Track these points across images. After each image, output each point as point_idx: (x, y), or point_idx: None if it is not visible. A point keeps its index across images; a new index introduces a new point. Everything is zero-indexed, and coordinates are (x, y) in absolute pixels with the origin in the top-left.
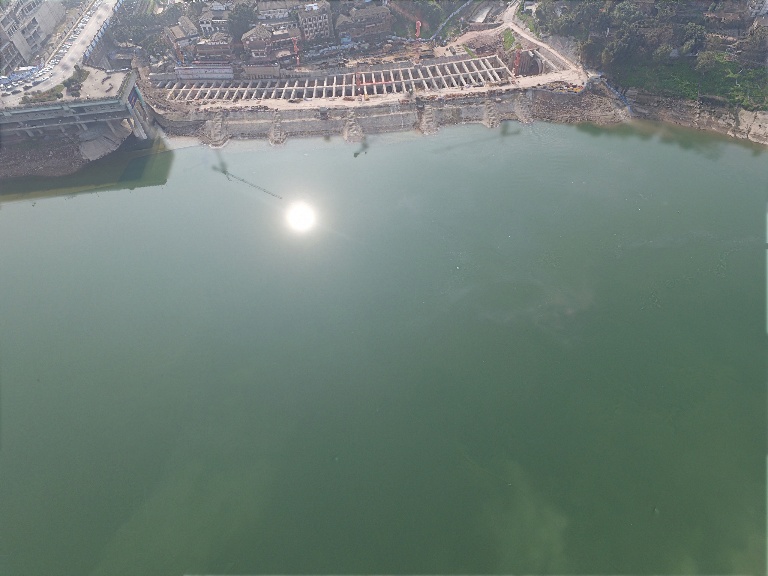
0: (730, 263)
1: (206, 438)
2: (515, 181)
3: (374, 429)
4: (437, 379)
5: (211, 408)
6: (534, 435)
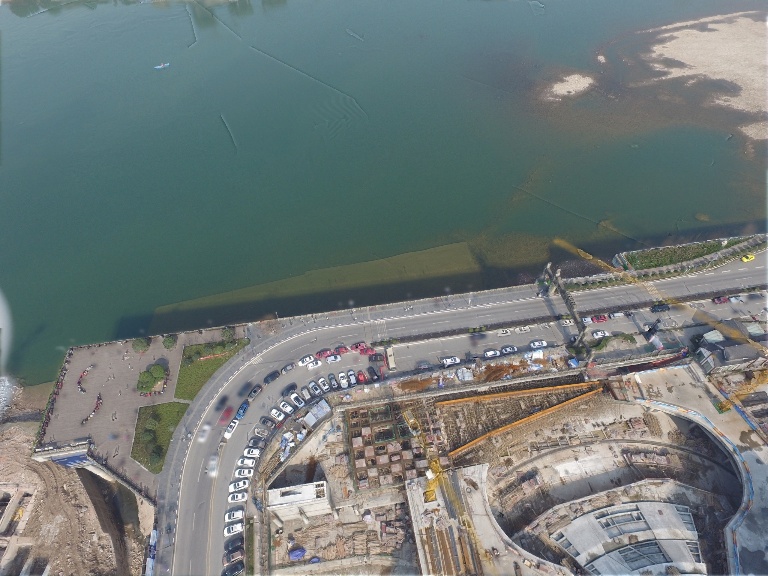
0: None
1: (88, 126)
2: None
3: None
4: None
5: (82, 135)
6: None
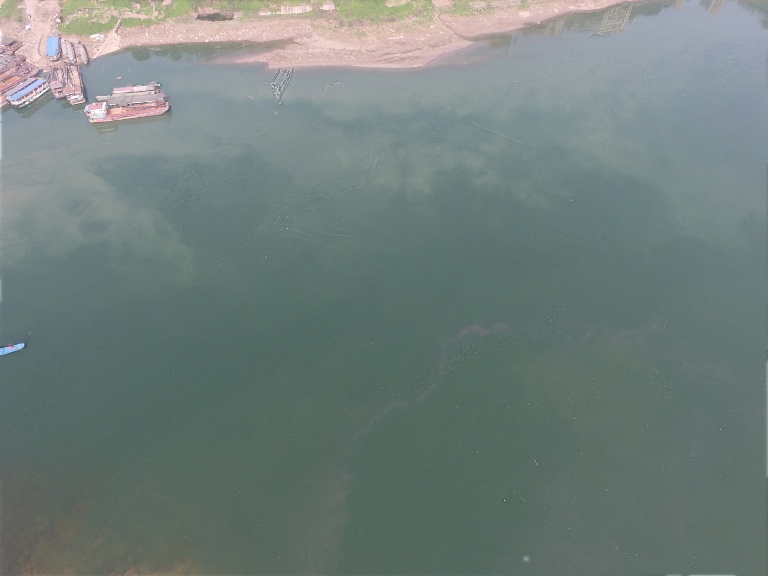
0: None
1: None
2: (745, 569)
3: None
4: (743, 269)
5: None
6: (660, 225)
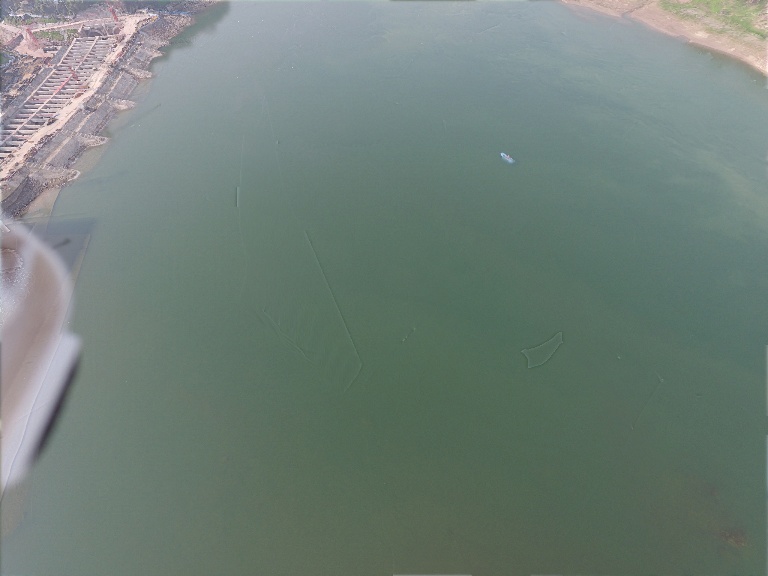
0: (316, 12)
1: (383, 138)
2: (226, 51)
3: (383, 94)
4: (361, 77)
5: (365, 139)
6: (393, 54)
